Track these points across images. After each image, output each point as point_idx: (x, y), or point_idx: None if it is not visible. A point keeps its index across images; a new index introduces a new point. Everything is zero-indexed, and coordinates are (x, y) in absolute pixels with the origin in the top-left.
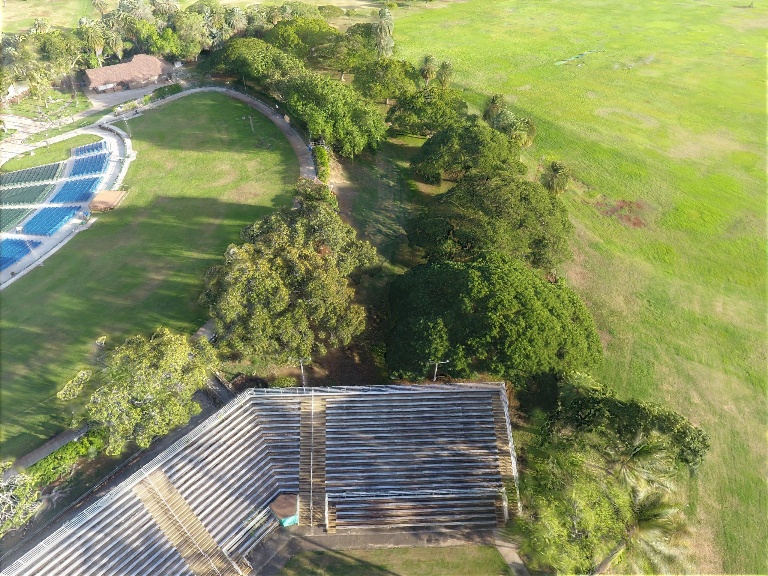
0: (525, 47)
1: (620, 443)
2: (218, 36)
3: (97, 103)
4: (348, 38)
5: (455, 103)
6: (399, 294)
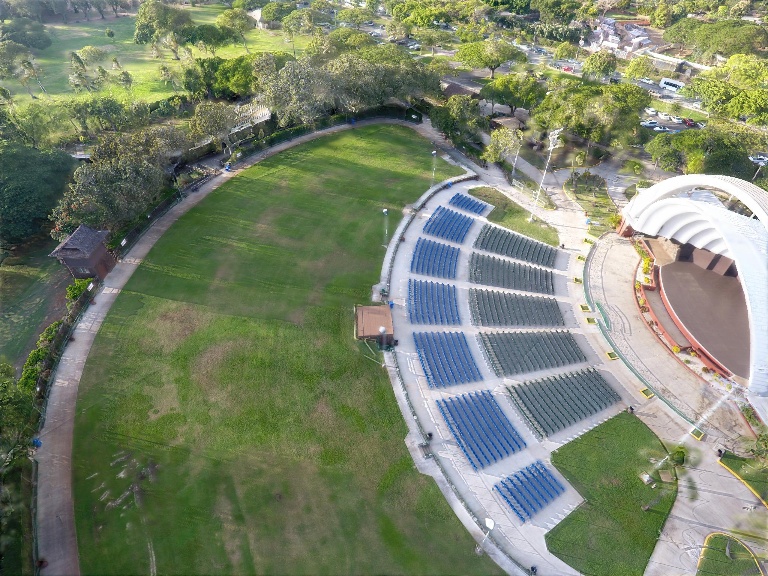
0: None
1: (3, 110)
2: None
3: None
4: None
5: None
6: (55, 189)
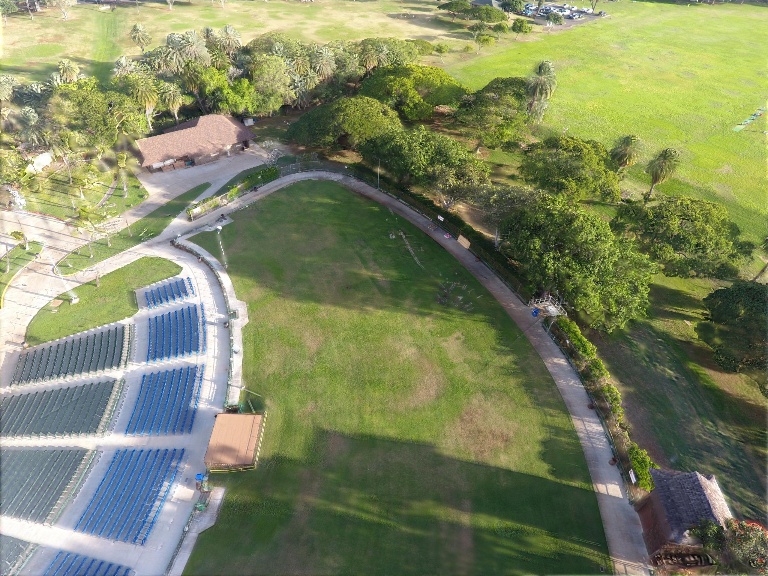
0: (676, 102)
1: None
2: (301, 85)
3: (154, 190)
4: (494, 100)
5: (729, 228)
6: None
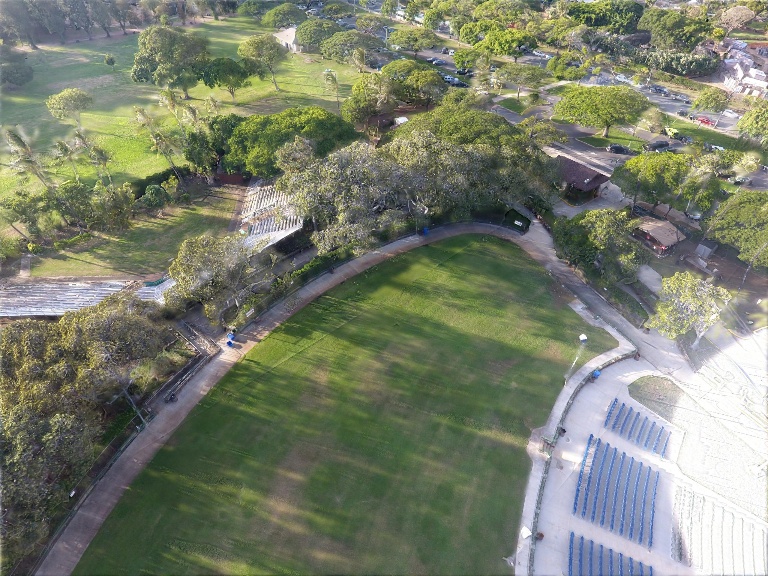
0: None
1: None
2: None
3: None
4: None
5: None
6: None
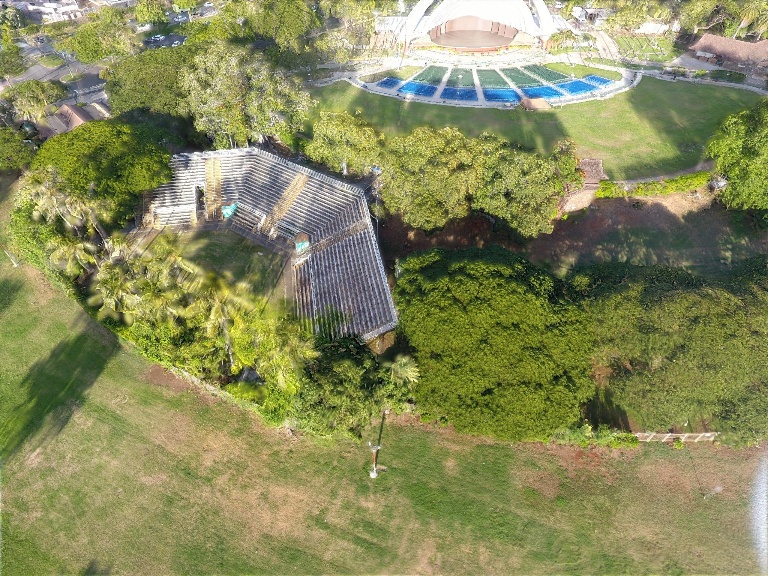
0: None
1: (313, 353)
2: None
3: (677, 62)
4: None
5: None
6: None
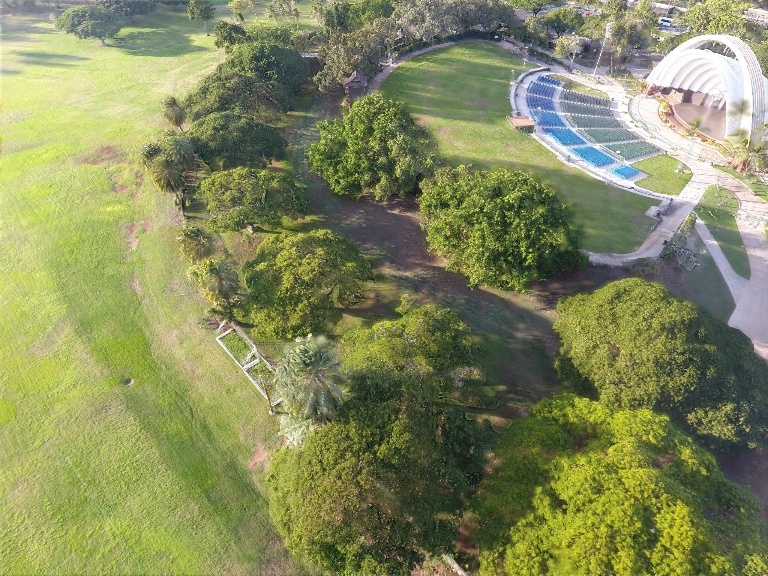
0: None
1: None
2: None
3: None
4: None
5: None
6: None
